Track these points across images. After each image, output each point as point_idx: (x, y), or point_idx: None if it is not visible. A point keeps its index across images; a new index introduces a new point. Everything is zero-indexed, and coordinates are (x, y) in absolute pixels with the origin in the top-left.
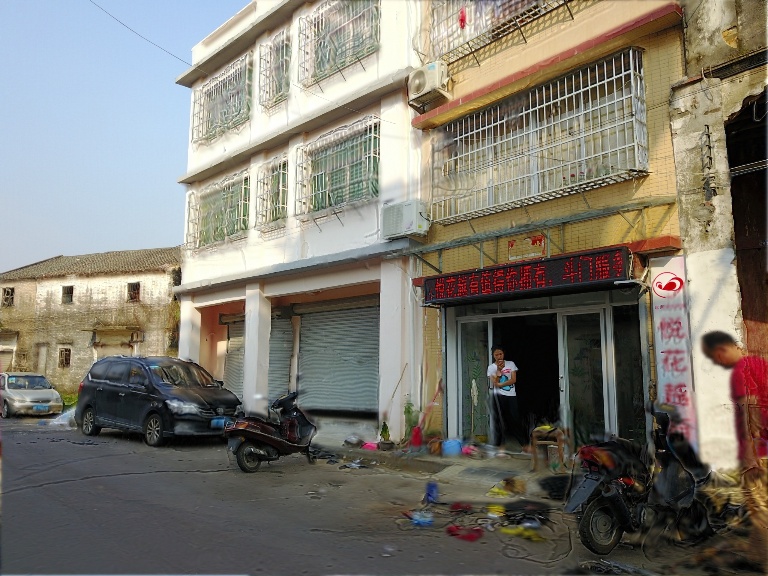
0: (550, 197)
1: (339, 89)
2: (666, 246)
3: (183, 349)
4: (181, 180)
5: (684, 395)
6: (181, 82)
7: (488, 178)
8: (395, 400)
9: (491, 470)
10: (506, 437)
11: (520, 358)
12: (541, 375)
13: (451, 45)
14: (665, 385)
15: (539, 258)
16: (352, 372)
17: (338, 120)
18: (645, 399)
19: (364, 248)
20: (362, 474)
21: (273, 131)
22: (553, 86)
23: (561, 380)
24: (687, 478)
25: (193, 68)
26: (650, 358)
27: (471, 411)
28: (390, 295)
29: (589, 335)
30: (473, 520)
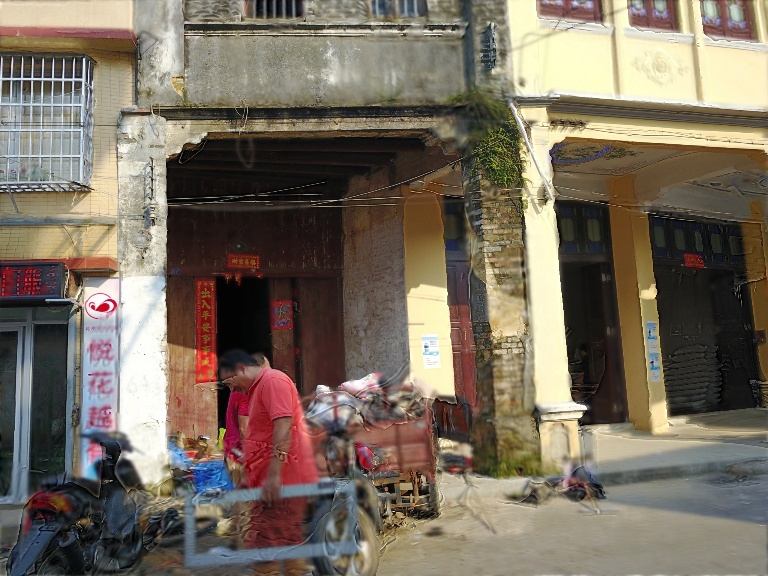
0: None
1: None
2: (105, 267)
3: None
4: None
5: (108, 417)
6: None
7: None
8: None
9: None
10: None
11: None
12: None
13: None
14: (90, 408)
15: None
16: None
17: None
18: (67, 425)
19: None
20: None
21: None
22: None
23: None
24: (131, 504)
25: None
26: (76, 381)
27: None
28: None
29: (2, 356)
30: None
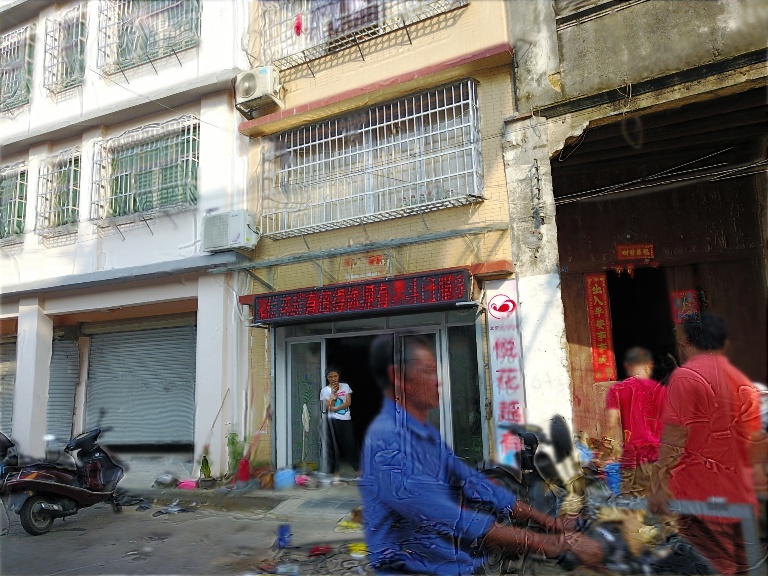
0: (390, 216)
1: (149, 82)
2: (502, 270)
3: None
4: None
5: (517, 412)
6: None
7: (325, 193)
8: (215, 430)
9: (332, 501)
10: (340, 463)
11: (355, 380)
12: (377, 397)
13: (285, 51)
14: (500, 403)
15: (383, 277)
16: (156, 400)
17: (147, 116)
18: (482, 417)
19: (180, 261)
20: (185, 520)
21: (61, 120)
22: (394, 106)
23: (398, 401)
24: (552, 496)
25: None
26: (486, 377)
27: (302, 438)
28: (210, 314)
29: (425, 355)
30: (338, 564)
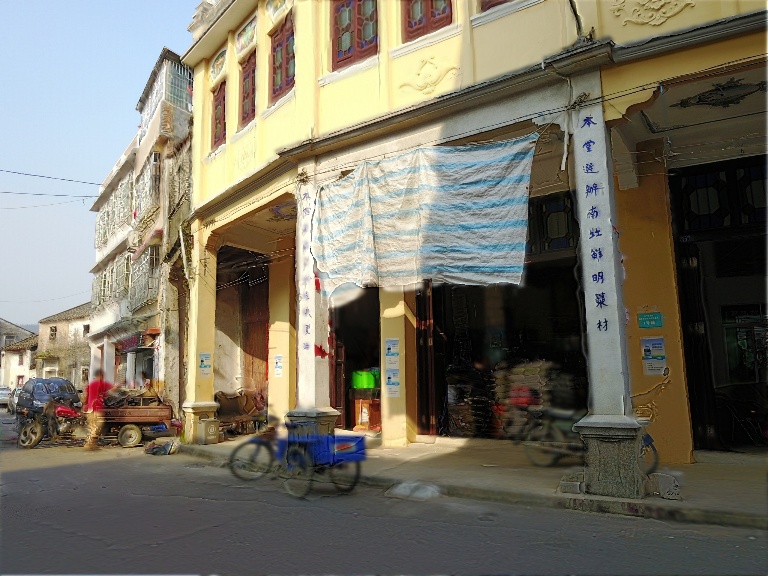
0: None
1: None
2: None
3: (91, 372)
4: (89, 271)
5: None
6: (92, 210)
7: None
8: None
9: None
10: None
11: None
12: None
13: None
14: None
15: None
16: None
17: None
18: None
19: None
20: None
21: None
22: None
23: None
24: None
25: (92, 205)
26: None
27: None
28: None
29: None
30: None
